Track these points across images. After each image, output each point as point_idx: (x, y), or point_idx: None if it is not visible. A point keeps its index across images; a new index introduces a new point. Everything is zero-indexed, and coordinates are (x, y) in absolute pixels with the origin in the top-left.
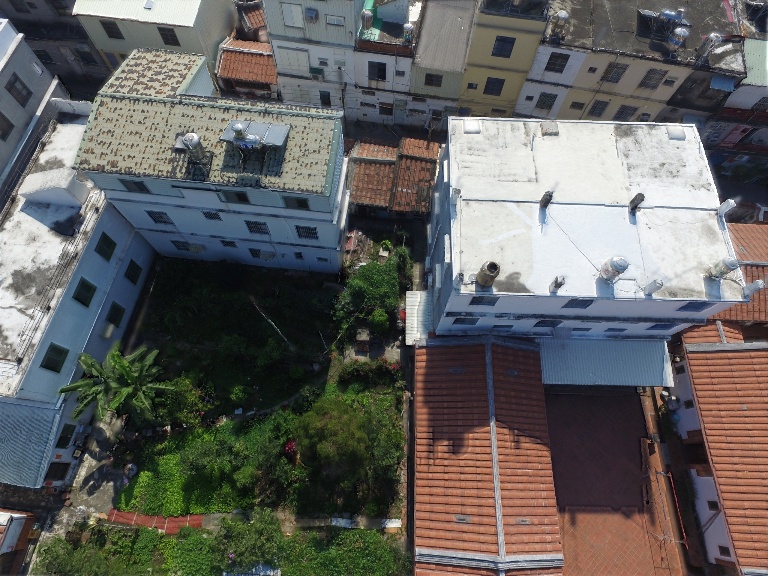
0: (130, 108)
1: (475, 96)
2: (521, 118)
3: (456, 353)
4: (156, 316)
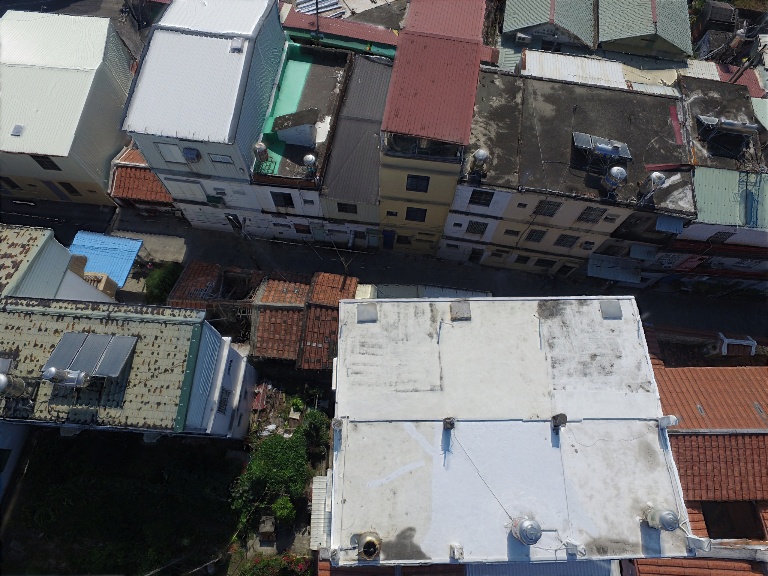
0: None
1: (397, 221)
2: (427, 298)
3: (363, 573)
4: (26, 509)
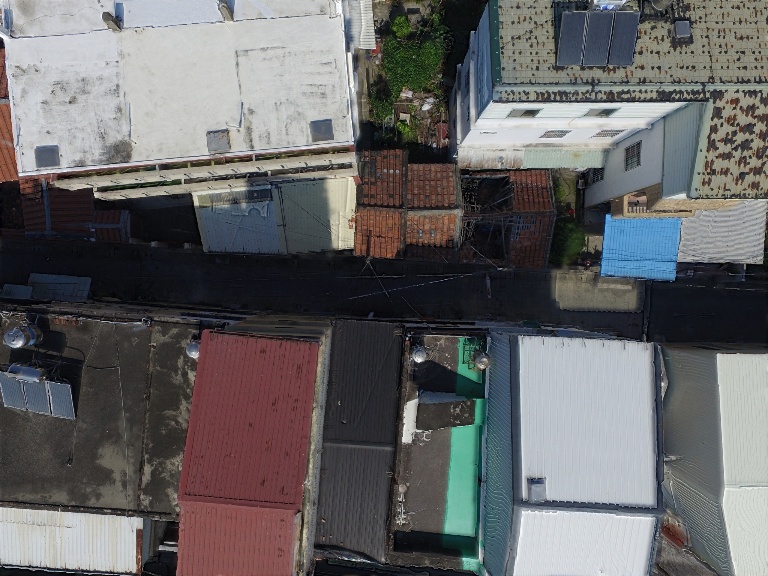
0: (763, 70)
1: None
2: None
3: None
4: None
